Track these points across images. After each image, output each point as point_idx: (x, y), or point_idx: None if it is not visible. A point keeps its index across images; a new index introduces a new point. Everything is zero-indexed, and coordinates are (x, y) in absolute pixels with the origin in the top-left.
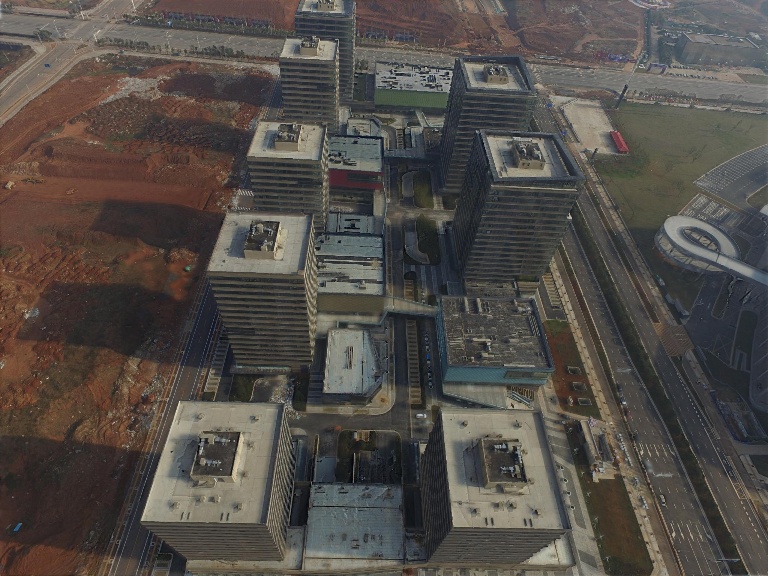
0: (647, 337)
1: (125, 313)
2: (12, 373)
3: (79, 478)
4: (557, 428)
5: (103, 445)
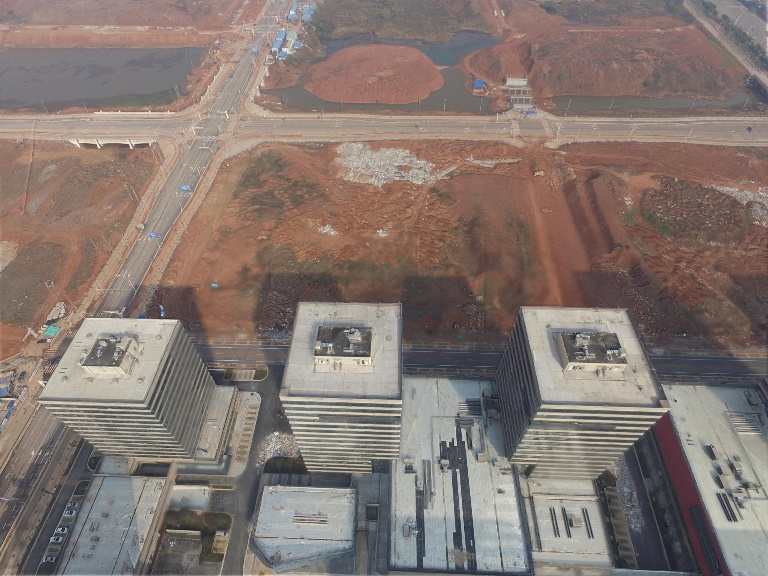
0: None
1: (383, 289)
2: (326, 241)
3: (239, 306)
4: None
5: (262, 312)
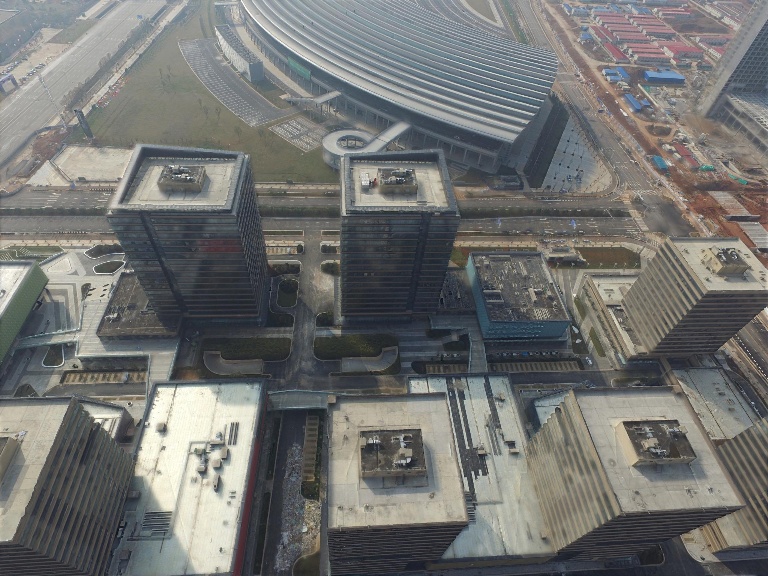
0: None
1: None
2: None
3: None
4: (555, 273)
5: None
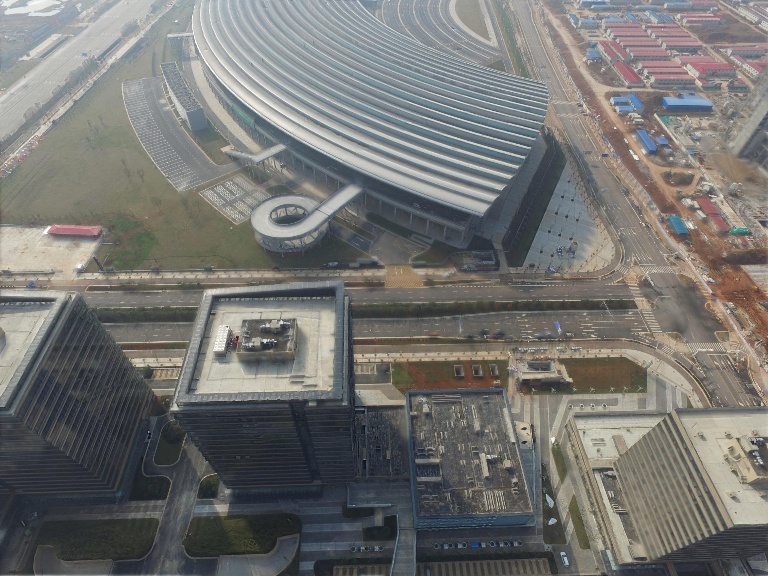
0: (404, 297)
1: None
2: None
3: None
4: (529, 402)
5: None
